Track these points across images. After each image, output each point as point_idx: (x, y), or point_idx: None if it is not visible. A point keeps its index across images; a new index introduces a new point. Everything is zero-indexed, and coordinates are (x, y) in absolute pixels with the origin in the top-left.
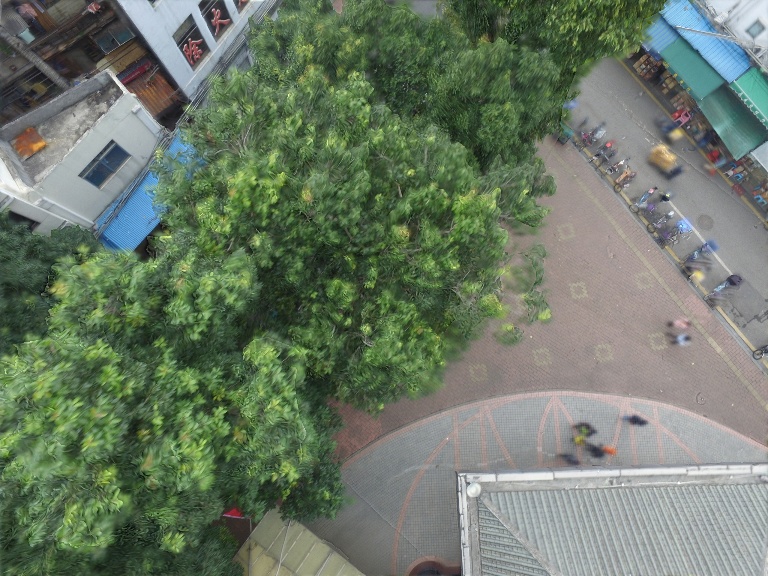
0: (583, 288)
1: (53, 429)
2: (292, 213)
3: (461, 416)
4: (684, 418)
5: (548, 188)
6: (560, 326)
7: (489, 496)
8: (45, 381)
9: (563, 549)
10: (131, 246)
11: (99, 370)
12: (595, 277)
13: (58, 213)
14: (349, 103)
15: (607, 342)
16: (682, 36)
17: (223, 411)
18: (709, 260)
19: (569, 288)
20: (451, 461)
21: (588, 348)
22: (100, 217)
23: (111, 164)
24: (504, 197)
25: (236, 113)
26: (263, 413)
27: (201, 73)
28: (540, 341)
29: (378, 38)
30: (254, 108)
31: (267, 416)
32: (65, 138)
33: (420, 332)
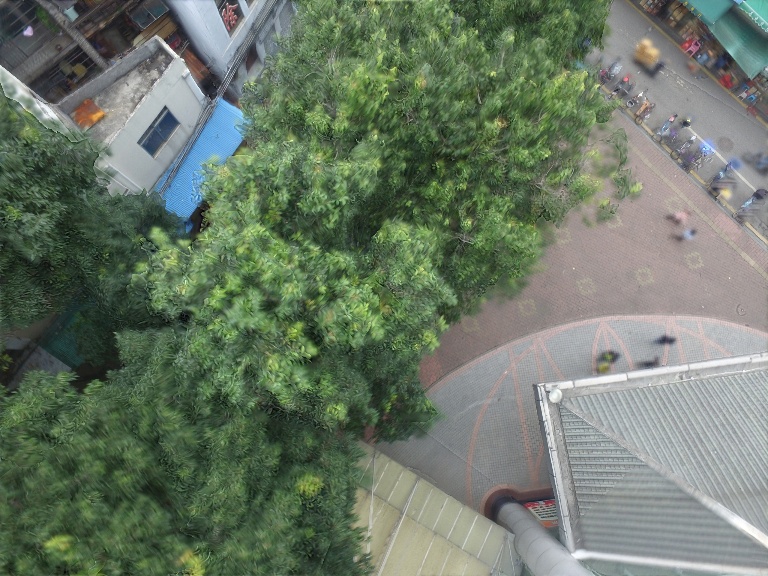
0: (617, 218)
1: (260, 277)
2: (395, 115)
3: (516, 350)
4: (728, 329)
5: None
6: (600, 256)
7: (570, 401)
8: (243, 239)
9: (649, 437)
10: (187, 213)
11: (267, 246)
12: (627, 206)
13: (120, 182)
14: (434, 11)
15: (646, 266)
16: None
17: (370, 286)
18: (733, 179)
19: (604, 219)
20: (512, 393)
21: (629, 274)
22: (154, 188)
23: (163, 132)
24: None
25: (333, 27)
26: (409, 282)
27: (237, 39)
28: (583, 272)
29: None
30: None
31: (416, 282)
32: (122, 107)
33: None
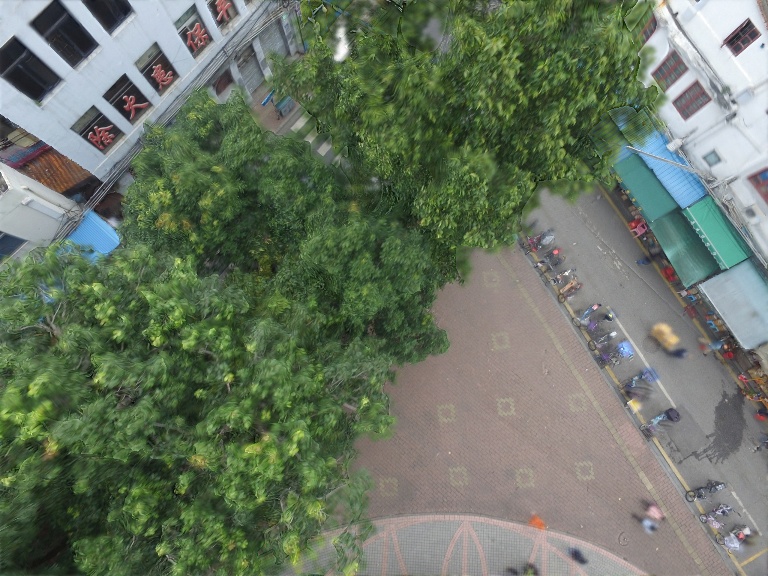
0: (511, 405)
1: None
2: None
3: None
4: (602, 559)
5: (439, 345)
6: (482, 444)
7: None
8: None
9: None
10: None
11: None
12: (525, 394)
13: None
14: (155, 304)
15: (530, 467)
16: None
17: None
18: (650, 386)
19: (496, 403)
20: None
21: (509, 471)
22: None
23: (3, 250)
24: (358, 385)
25: (19, 312)
26: None
27: (114, 156)
28: (458, 459)
29: (257, 177)
30: (64, 287)
31: None
32: None
33: (231, 548)
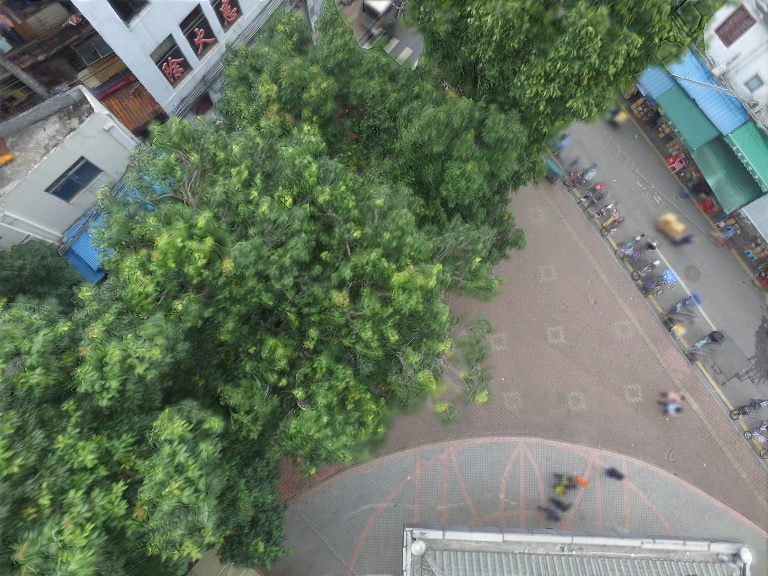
0: (560, 333)
1: None
2: (224, 273)
3: (425, 456)
4: (653, 475)
5: (517, 242)
6: (534, 370)
7: (434, 554)
8: None
9: None
10: (99, 261)
11: None
12: (574, 322)
13: (22, 227)
14: (294, 160)
15: (581, 390)
16: (679, 83)
17: (123, 487)
18: (693, 313)
19: (546, 332)
20: (410, 501)
21: (560, 395)
22: (69, 230)
23: (82, 179)
24: (461, 258)
25: (174, 165)
26: None
27: (182, 91)
28: (512, 384)
29: (349, 79)
30: (200, 155)
31: (164, 500)
32: (33, 152)
33: (357, 398)
